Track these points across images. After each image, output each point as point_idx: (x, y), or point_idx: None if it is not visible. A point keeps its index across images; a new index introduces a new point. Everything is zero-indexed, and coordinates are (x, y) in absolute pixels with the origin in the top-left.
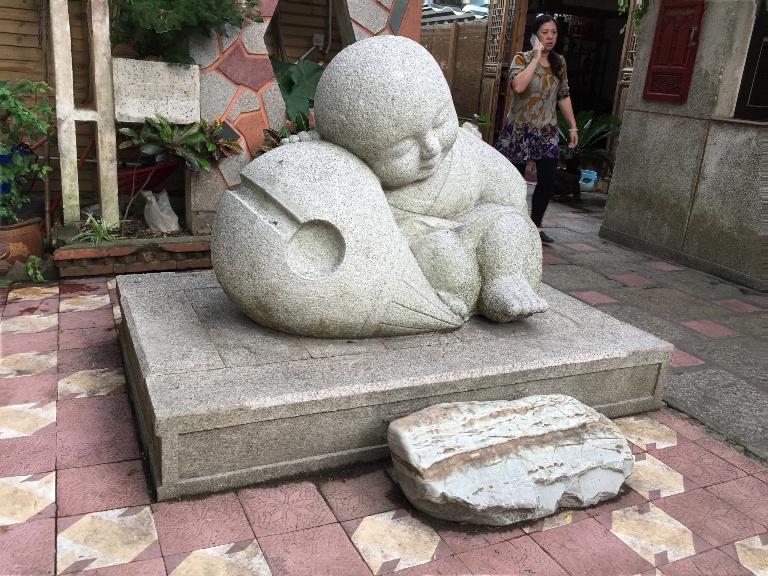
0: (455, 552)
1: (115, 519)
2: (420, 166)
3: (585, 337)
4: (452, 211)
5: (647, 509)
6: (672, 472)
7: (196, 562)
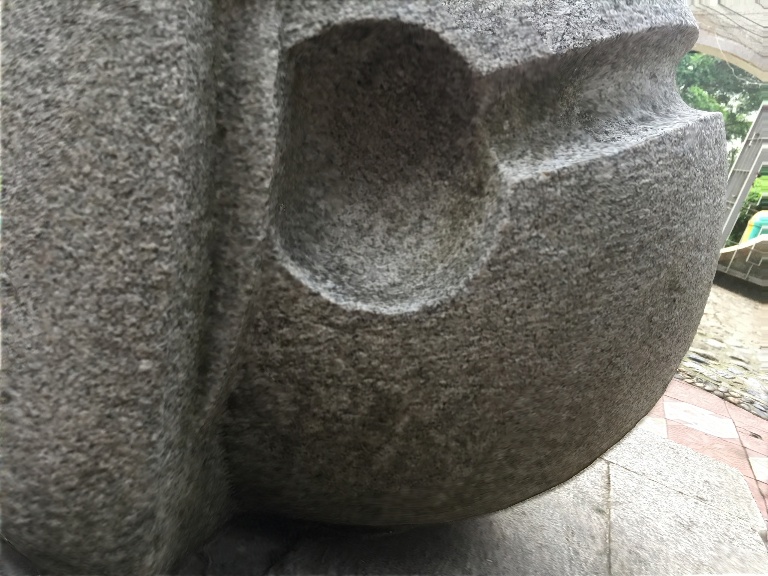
0: None
1: None
2: None
3: None
4: None
5: None
6: None
7: None
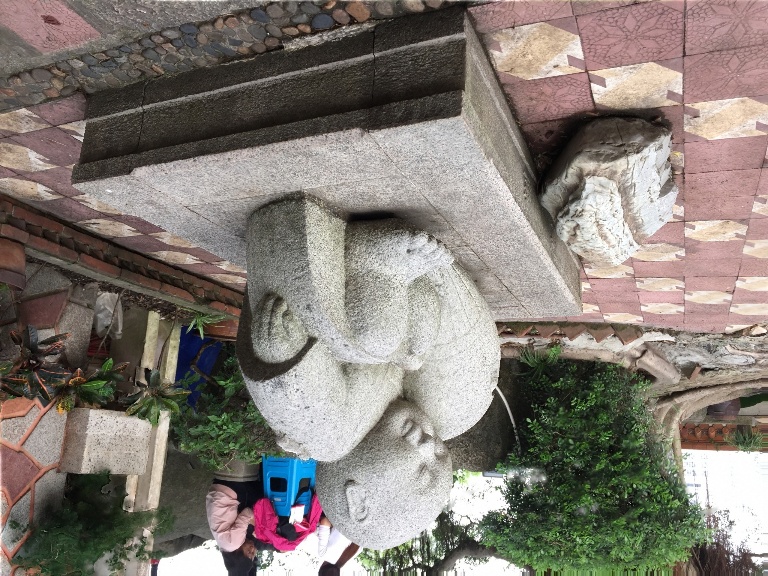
0: None
1: None
2: None
3: None
4: (381, 365)
5: (695, 111)
6: (641, 69)
7: None
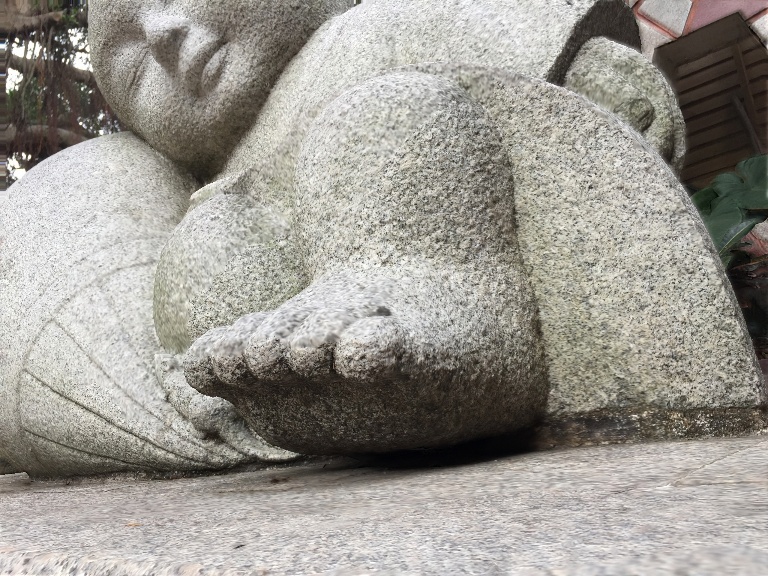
0: None
1: None
2: (183, 89)
3: None
4: None
5: None
6: None
7: None
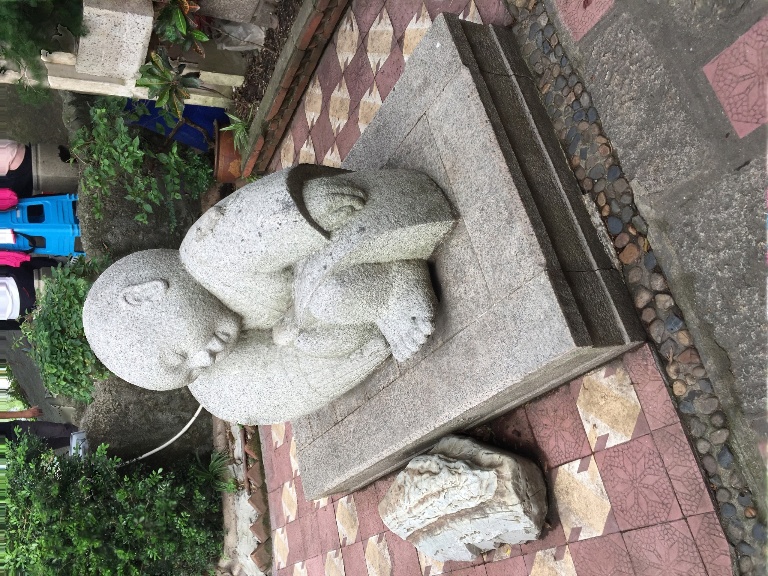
0: (451, 569)
1: (346, 506)
2: None
3: (486, 341)
4: (286, 304)
5: (561, 555)
6: (603, 499)
7: (370, 548)
